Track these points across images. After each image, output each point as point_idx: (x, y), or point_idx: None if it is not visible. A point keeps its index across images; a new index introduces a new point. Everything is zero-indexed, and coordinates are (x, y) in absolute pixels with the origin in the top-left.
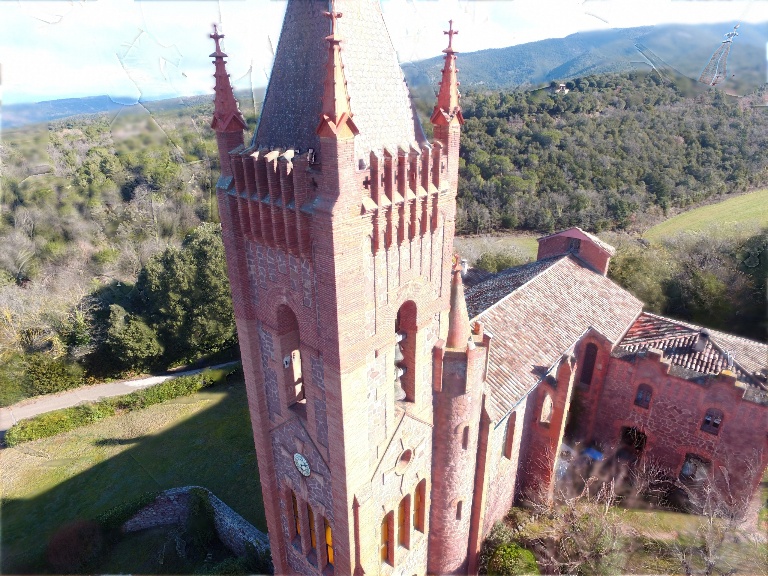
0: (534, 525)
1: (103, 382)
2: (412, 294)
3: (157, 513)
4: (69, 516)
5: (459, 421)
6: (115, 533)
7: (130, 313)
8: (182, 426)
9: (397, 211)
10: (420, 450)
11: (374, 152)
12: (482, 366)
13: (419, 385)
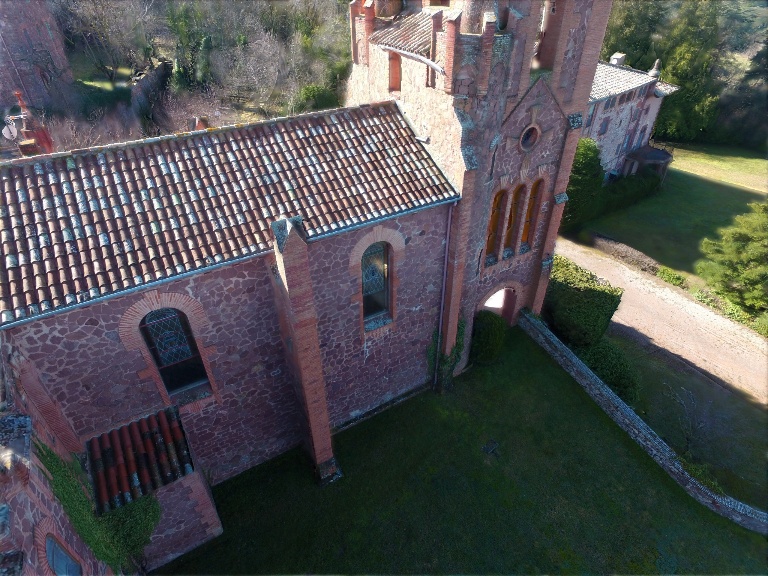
0: None
1: None
2: None
3: None
4: None
5: None
6: None
7: None
8: None
9: None
10: None
11: None
12: None
13: None
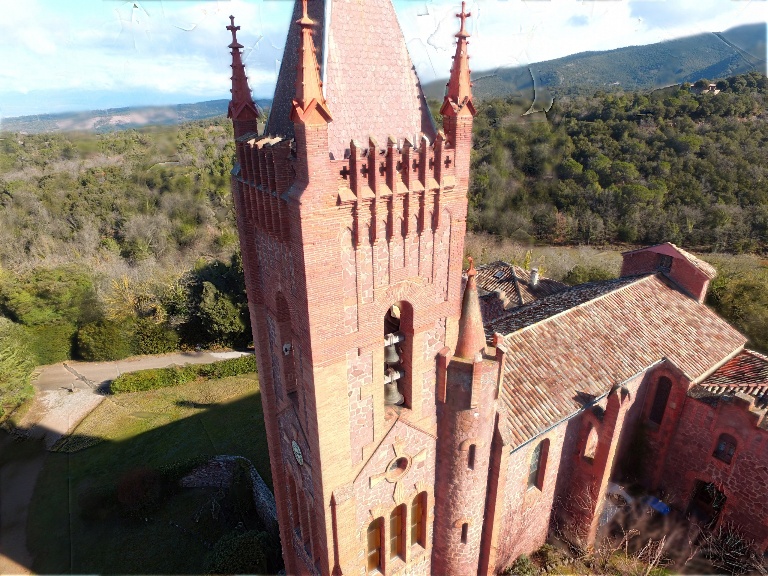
0: (567, 569)
1: (194, 350)
2: (407, 294)
3: (209, 475)
4: (142, 463)
5: (464, 437)
6: (172, 485)
7: (220, 291)
8: (247, 400)
9: (385, 205)
10: (419, 460)
11: (353, 141)
12: (493, 382)
13: (417, 392)
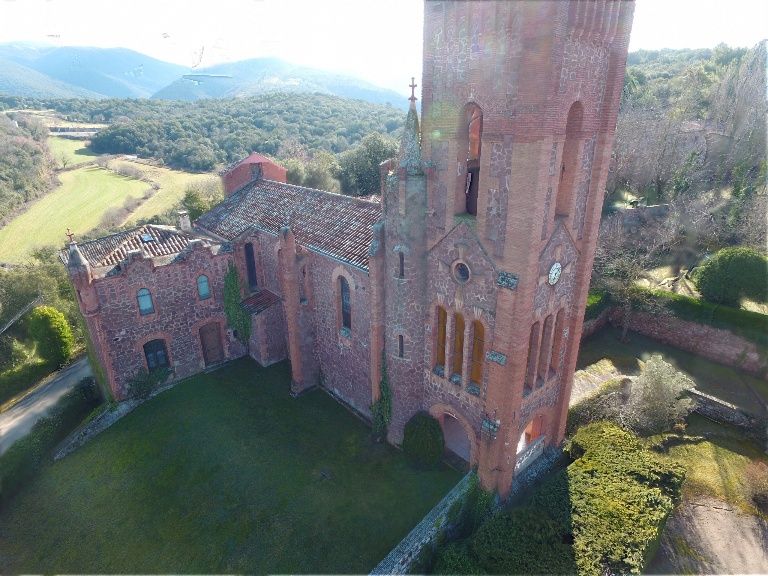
0: None
1: None
2: None
3: None
4: None
5: None
6: None
7: None
8: None
9: None
10: None
11: None
12: None
13: None
